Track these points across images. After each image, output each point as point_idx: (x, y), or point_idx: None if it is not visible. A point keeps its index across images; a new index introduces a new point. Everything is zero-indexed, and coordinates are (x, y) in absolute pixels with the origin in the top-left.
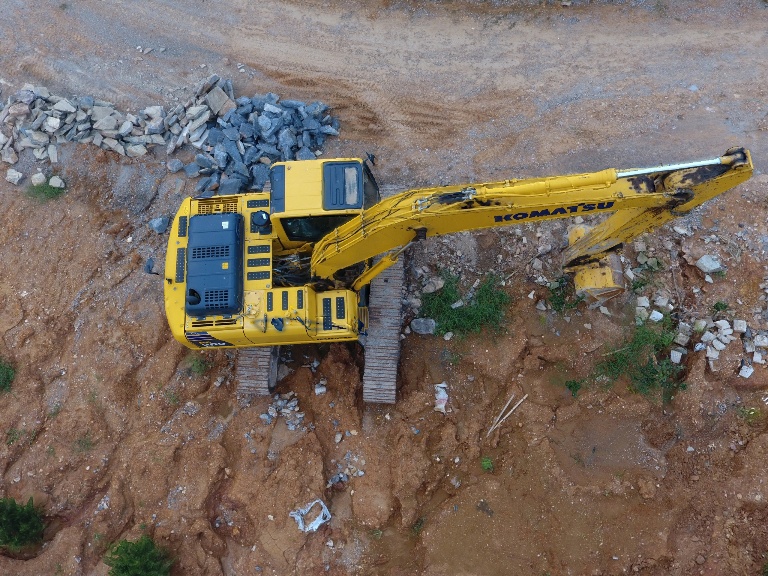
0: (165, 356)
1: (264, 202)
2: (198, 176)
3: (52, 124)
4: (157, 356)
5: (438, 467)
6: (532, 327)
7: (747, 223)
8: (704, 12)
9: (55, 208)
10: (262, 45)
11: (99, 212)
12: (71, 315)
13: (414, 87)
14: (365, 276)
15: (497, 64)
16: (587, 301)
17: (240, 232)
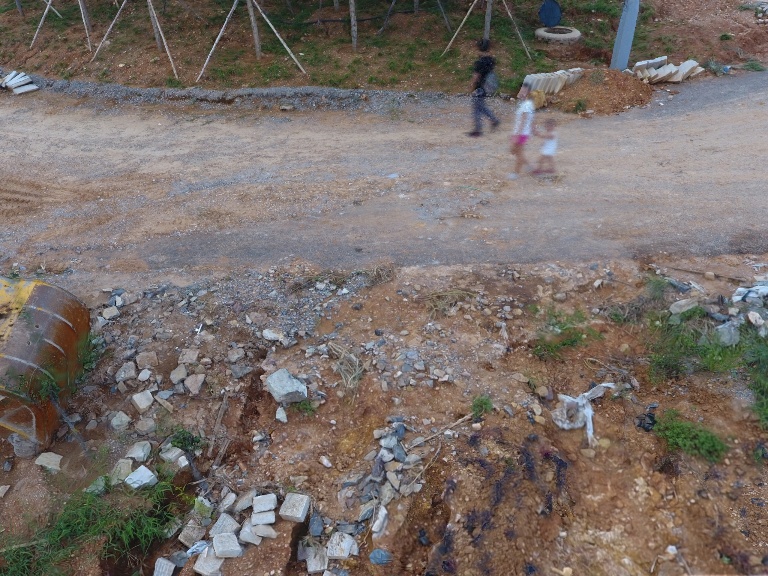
0: None
1: None
2: None
3: None
4: None
5: None
6: None
7: (390, 330)
8: (446, 116)
9: None
10: None
11: None
12: None
13: (33, 168)
14: None
15: (159, 152)
16: None
17: None
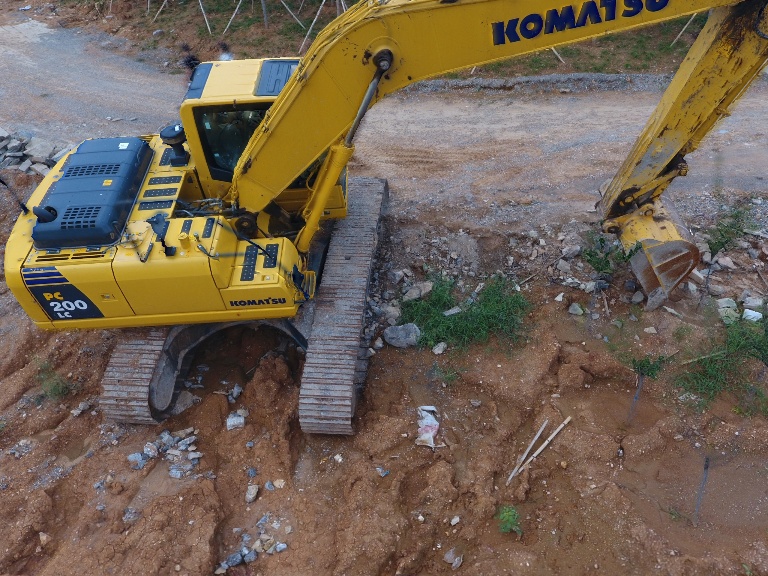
0: (12, 378)
1: None
2: None
3: None
4: None
5: (420, 527)
6: (565, 333)
7: None
8: None
9: None
10: None
11: None
12: None
13: (402, 140)
14: (311, 210)
15: (495, 125)
16: (643, 285)
17: (143, 159)
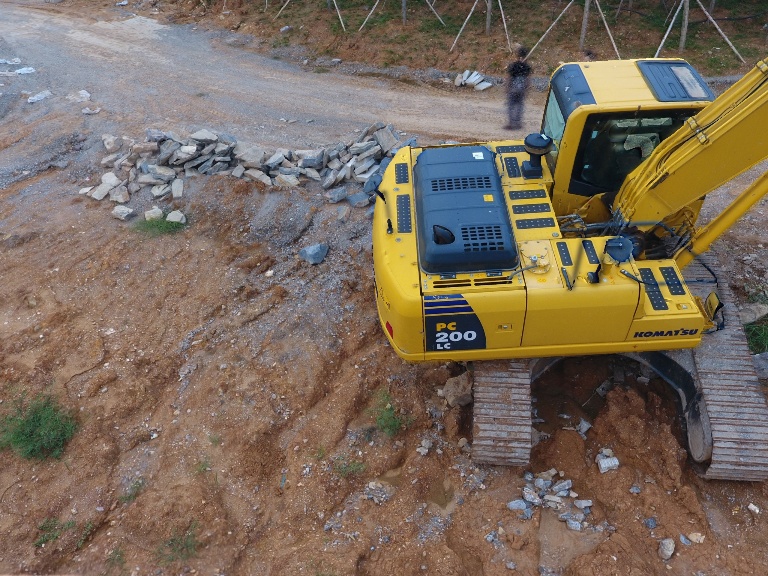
0: (328, 410)
1: (521, 147)
2: (366, 205)
3: (187, 150)
4: (311, 414)
5: None
6: None
7: None
8: None
9: (170, 242)
10: (420, 120)
11: (229, 245)
12: (176, 359)
13: None
14: (709, 229)
15: None
16: None
17: None
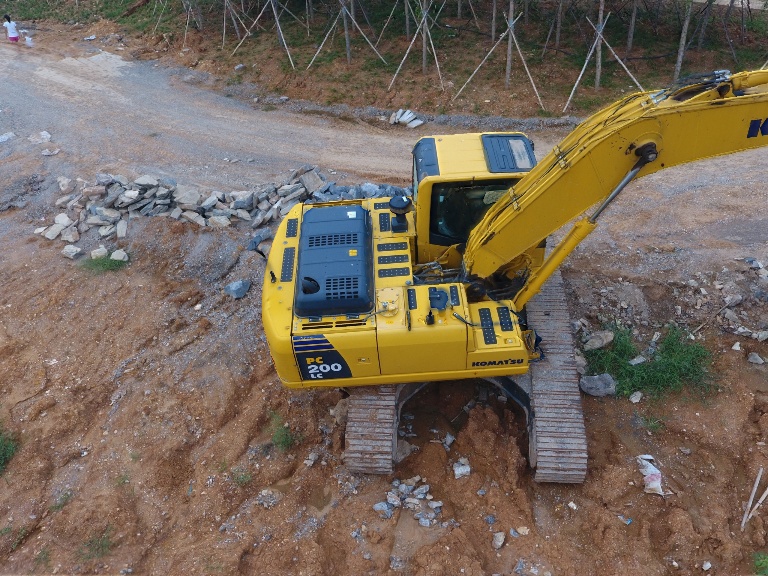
0: (234, 429)
1: None
2: None
3: (130, 194)
4: (221, 433)
5: (681, 573)
6: (753, 382)
7: None
8: None
9: (112, 279)
10: (353, 159)
11: (165, 281)
12: (109, 386)
13: None
14: (537, 275)
15: None
16: None
17: (368, 227)
